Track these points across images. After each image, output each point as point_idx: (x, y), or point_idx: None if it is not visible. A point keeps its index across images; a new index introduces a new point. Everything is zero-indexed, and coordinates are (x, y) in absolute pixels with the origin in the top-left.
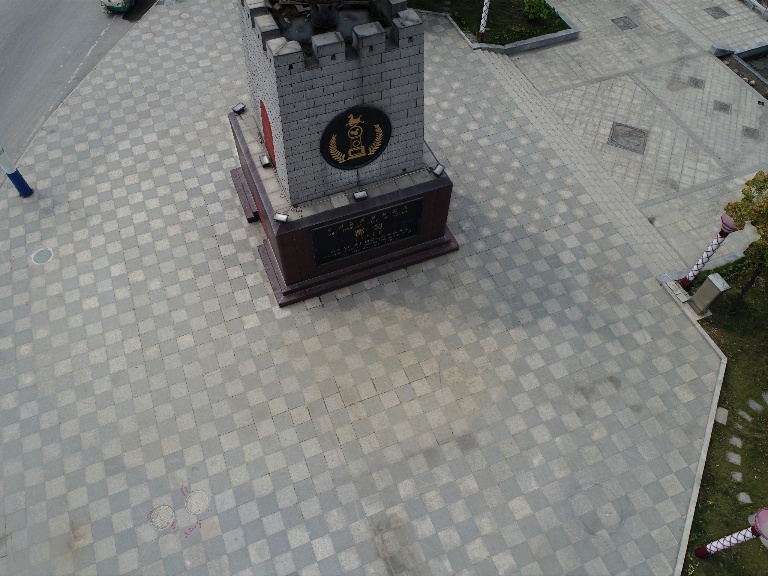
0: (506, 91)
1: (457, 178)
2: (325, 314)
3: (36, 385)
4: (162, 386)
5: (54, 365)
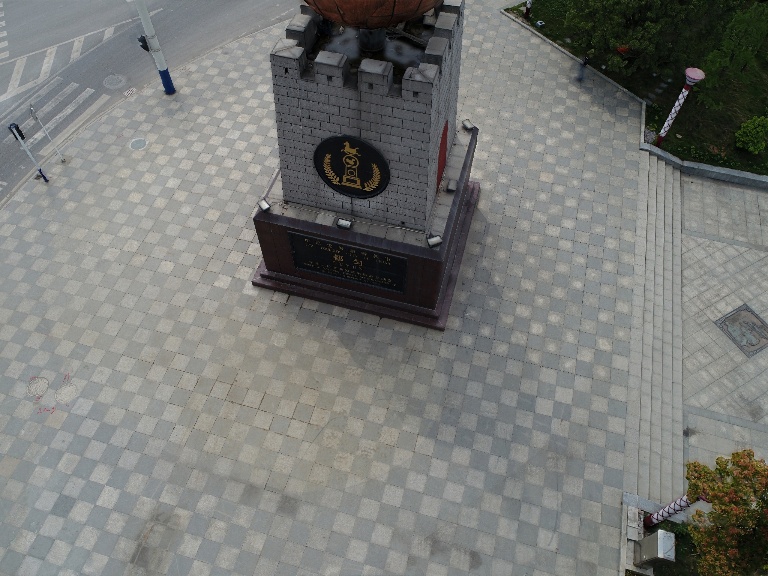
0: (637, 207)
1: (505, 264)
2: (281, 313)
3: (55, 235)
4: (122, 290)
5: (76, 228)
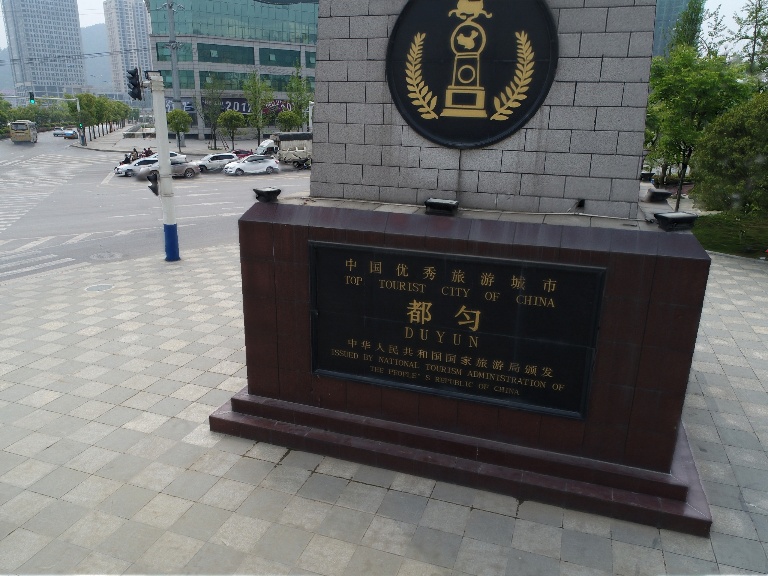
0: None
1: None
2: (261, 479)
3: None
4: None
5: None
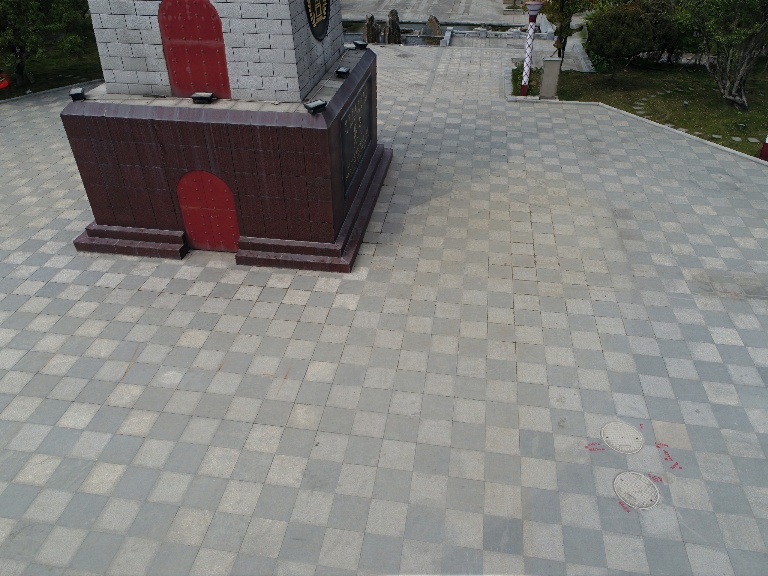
0: None
1: None
2: (393, 245)
3: None
4: (382, 421)
5: None
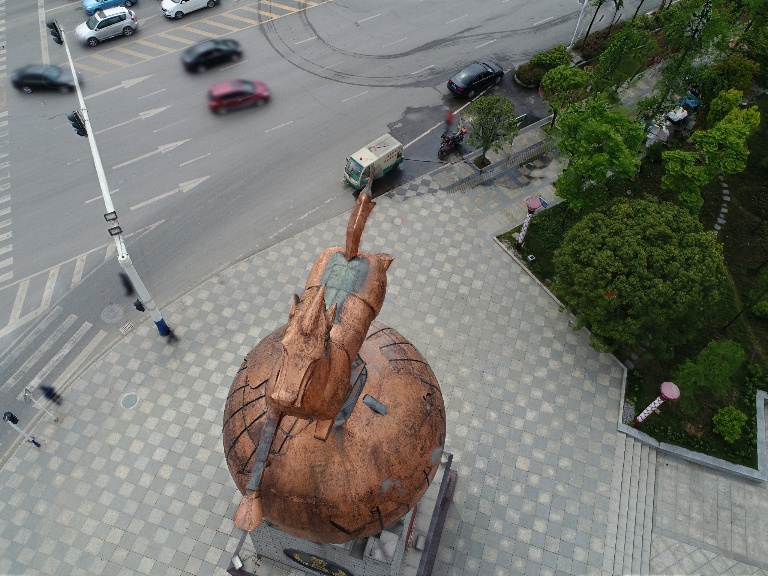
0: (609, 508)
1: None
2: None
3: (42, 518)
4: None
5: (63, 510)
